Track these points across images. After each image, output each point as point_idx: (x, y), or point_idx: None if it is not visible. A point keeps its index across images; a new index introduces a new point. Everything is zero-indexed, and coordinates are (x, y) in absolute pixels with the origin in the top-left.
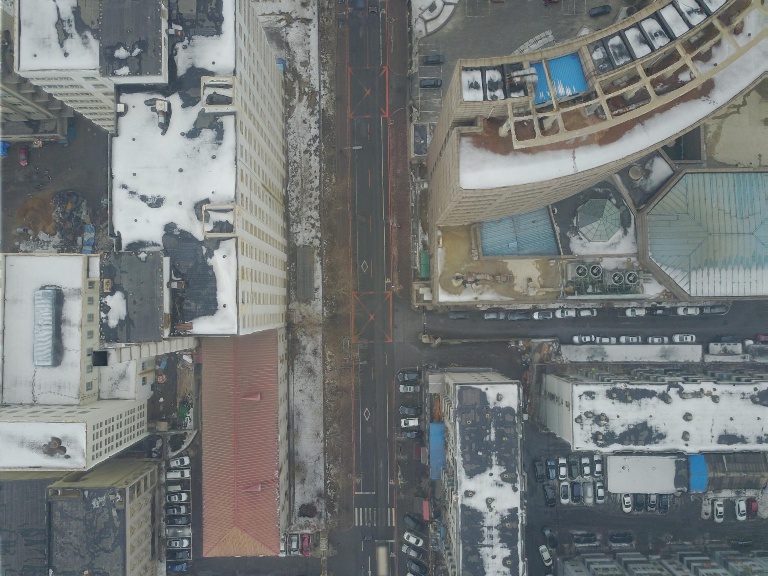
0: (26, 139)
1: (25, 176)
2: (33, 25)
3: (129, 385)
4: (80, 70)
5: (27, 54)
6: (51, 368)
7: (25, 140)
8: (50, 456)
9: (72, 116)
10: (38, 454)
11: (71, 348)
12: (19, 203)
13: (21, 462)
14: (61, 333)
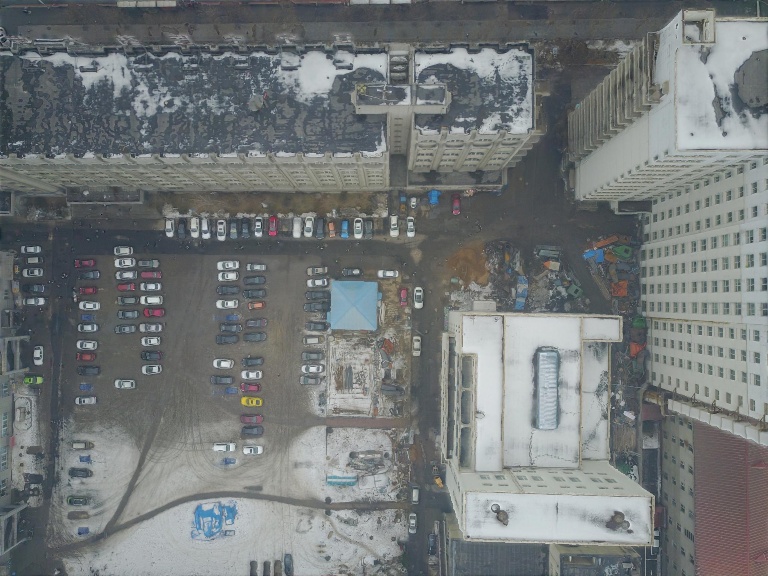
0: (461, 188)
1: (455, 225)
2: (688, 103)
3: (599, 445)
4: (742, 150)
5: (683, 133)
6: (548, 431)
7: (458, 189)
8: (613, 530)
9: (514, 166)
10: (601, 528)
11: (568, 411)
12: (449, 252)
13: (584, 536)
14: (558, 395)
